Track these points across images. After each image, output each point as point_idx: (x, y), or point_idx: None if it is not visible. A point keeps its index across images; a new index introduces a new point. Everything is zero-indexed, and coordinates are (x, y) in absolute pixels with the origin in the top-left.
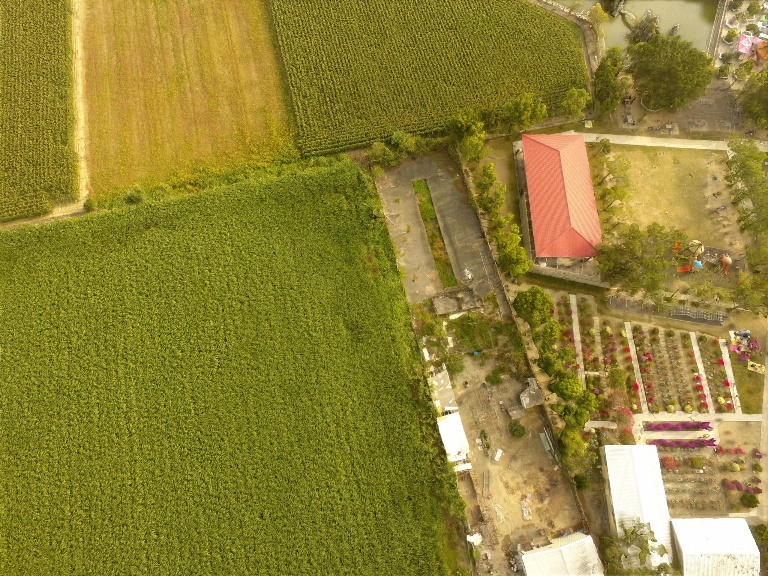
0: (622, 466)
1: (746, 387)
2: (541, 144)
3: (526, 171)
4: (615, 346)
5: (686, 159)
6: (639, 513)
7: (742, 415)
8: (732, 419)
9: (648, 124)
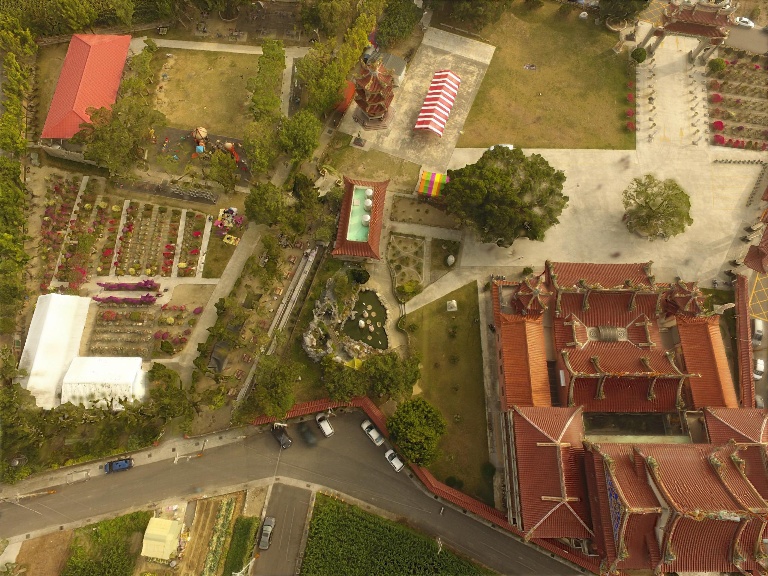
0: (41, 311)
1: (214, 256)
2: (82, 41)
3: (63, 65)
4: (107, 220)
5: (243, 63)
6: (35, 349)
7: (200, 279)
8: (190, 282)
9: (220, 32)
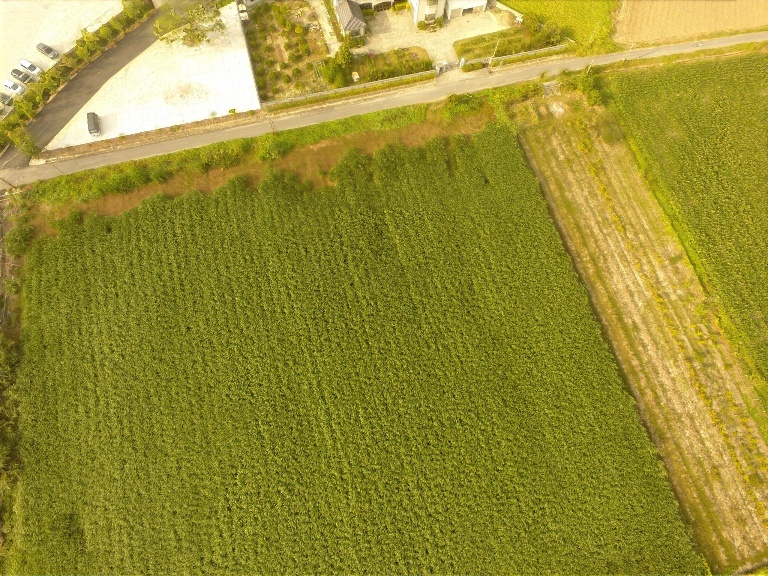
0: None
1: None
2: None
3: None
4: None
5: None
6: None
7: None
8: None
9: None
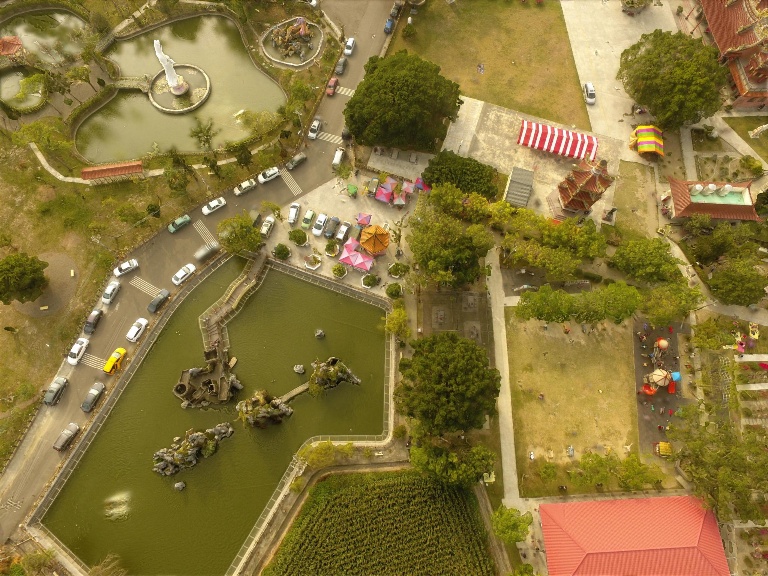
0: None
1: None
2: None
3: None
4: None
5: (523, 356)
6: None
7: None
8: None
9: None
